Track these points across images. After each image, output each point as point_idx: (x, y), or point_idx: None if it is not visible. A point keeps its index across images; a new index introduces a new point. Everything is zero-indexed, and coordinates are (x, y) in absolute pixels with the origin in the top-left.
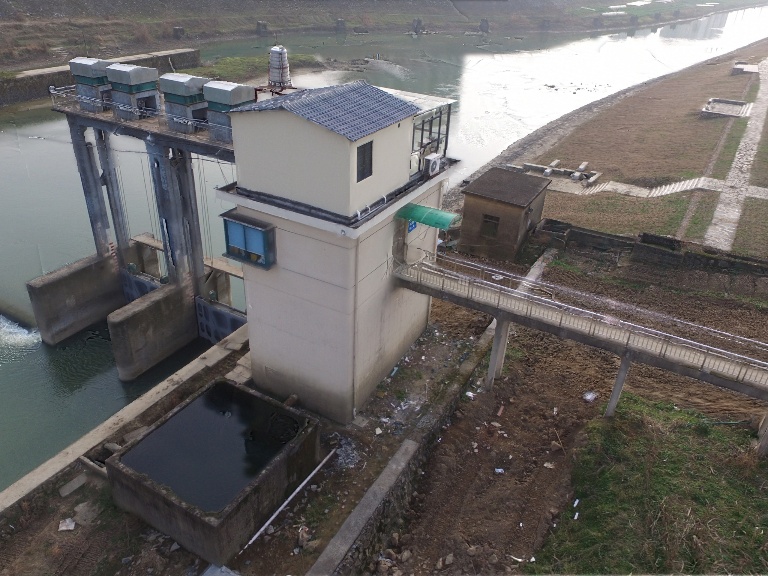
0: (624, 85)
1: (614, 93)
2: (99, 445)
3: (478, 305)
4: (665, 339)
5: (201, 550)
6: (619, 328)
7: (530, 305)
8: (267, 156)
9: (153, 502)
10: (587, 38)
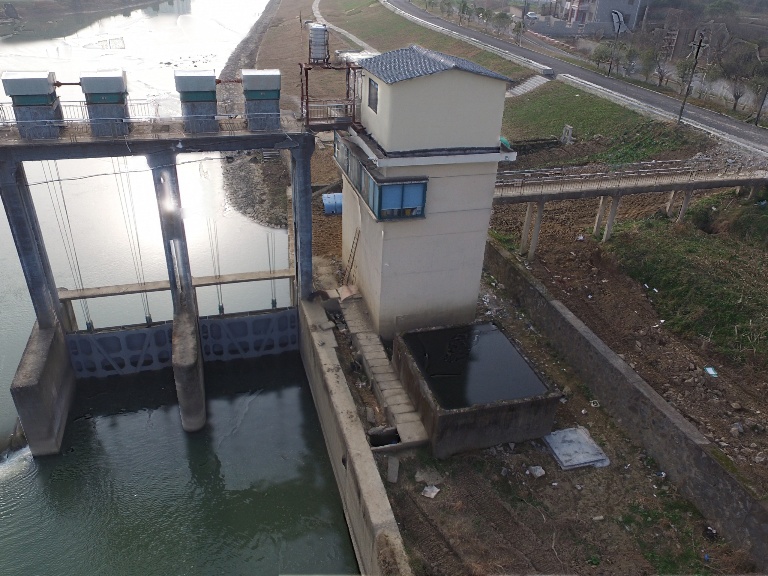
0: (226, 53)
1: (228, 61)
2: (366, 436)
3: (528, 198)
4: (639, 174)
5: (535, 431)
6: (615, 177)
7: (563, 183)
8: (425, 115)
9: (494, 419)
10: (155, 14)
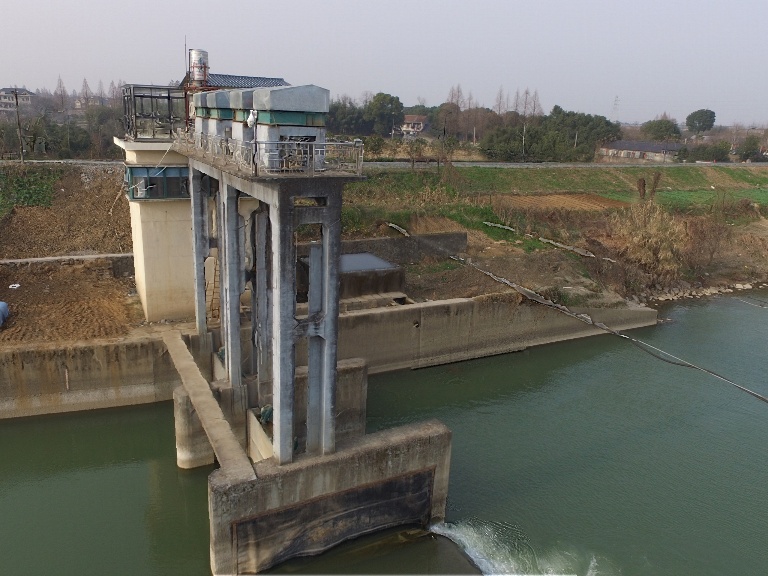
0: None
1: None
2: None
3: None
4: None
5: None
6: None
7: None
8: None
9: None
10: None
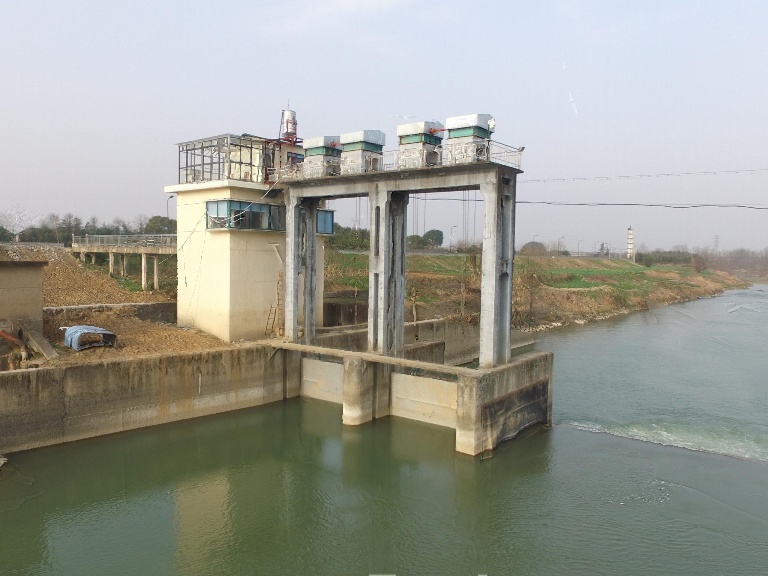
0: None
1: None
2: None
3: None
4: None
5: None
6: None
7: None
8: None
9: None
10: None
